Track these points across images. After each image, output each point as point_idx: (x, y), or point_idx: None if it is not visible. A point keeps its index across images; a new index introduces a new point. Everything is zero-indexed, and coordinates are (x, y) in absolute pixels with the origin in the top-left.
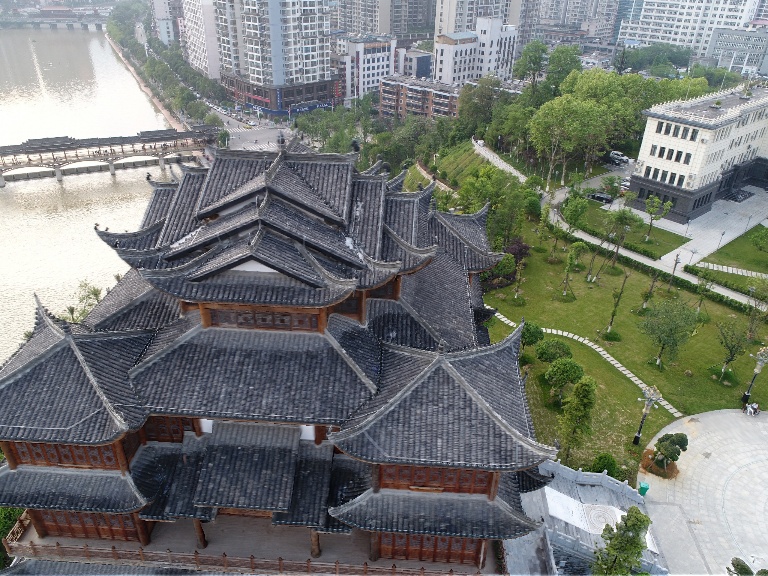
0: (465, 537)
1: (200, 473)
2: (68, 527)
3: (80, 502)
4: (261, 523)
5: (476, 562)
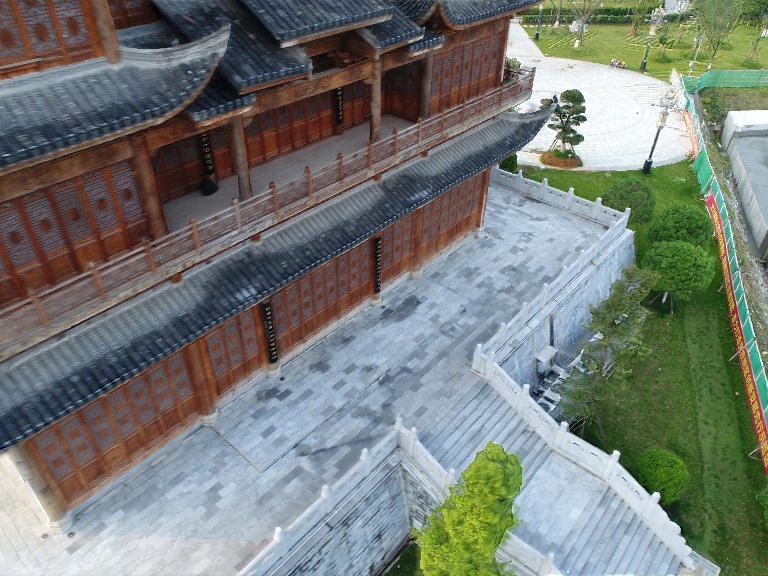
0: (524, 8)
1: (249, 4)
2: (9, 282)
3: (73, 126)
4: (280, 162)
5: (496, 87)
